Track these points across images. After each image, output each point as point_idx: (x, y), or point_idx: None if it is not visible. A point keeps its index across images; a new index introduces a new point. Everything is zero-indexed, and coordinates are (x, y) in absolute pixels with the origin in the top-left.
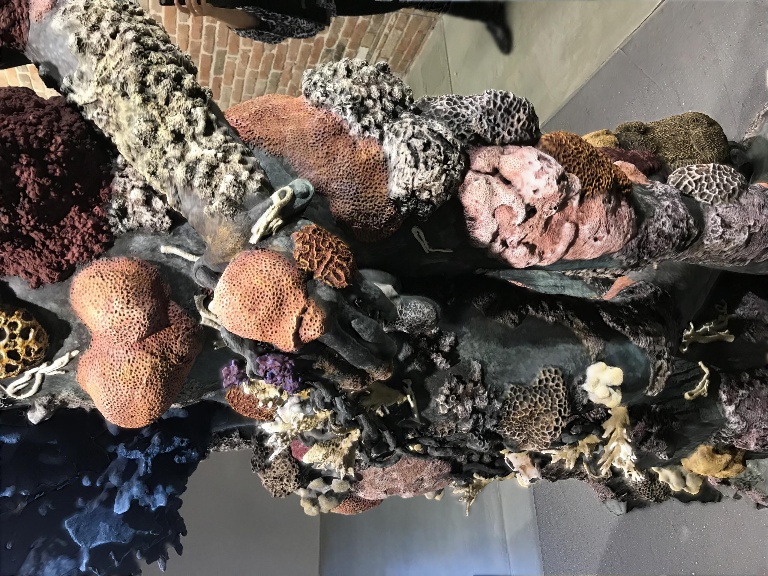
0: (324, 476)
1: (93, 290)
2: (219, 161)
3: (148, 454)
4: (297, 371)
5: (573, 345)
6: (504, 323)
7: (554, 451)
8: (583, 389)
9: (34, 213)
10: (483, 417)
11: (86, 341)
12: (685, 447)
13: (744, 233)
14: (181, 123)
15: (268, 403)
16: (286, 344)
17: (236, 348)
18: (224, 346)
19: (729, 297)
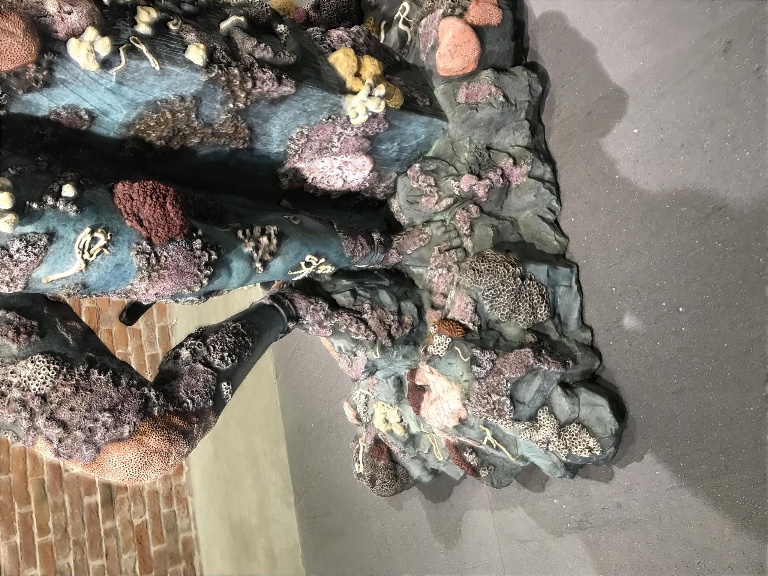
0: None
1: None
2: None
3: None
4: None
5: None
6: None
7: None
8: None
9: None
10: None
11: None
12: (320, 63)
13: None
14: None
15: None
16: None
17: None
18: None
19: None
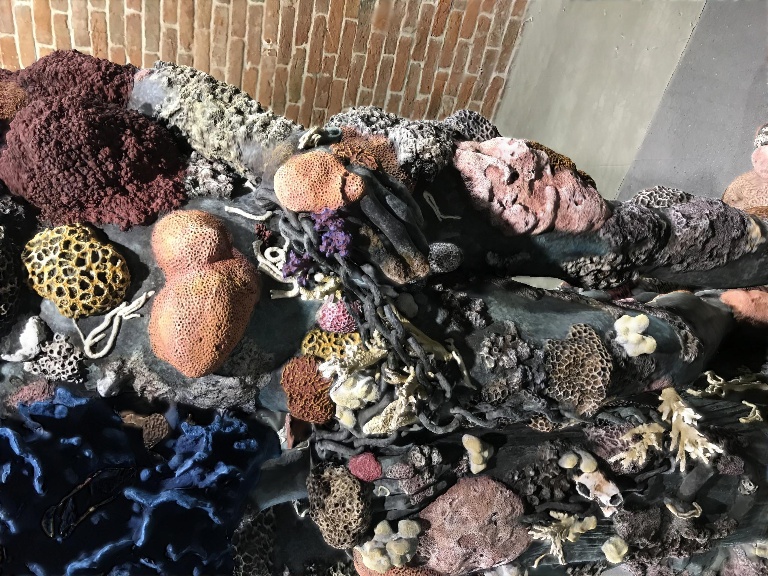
0: (388, 519)
1: (172, 226)
2: (270, 120)
3: (209, 429)
4: (347, 229)
5: (594, 311)
6: (525, 296)
7: (622, 453)
8: (618, 344)
9: (131, 167)
10: (530, 370)
11: (161, 283)
12: None
13: (705, 219)
14: (241, 105)
15: (324, 296)
16: (335, 197)
17: (293, 234)
18: (279, 297)
19: (748, 364)
